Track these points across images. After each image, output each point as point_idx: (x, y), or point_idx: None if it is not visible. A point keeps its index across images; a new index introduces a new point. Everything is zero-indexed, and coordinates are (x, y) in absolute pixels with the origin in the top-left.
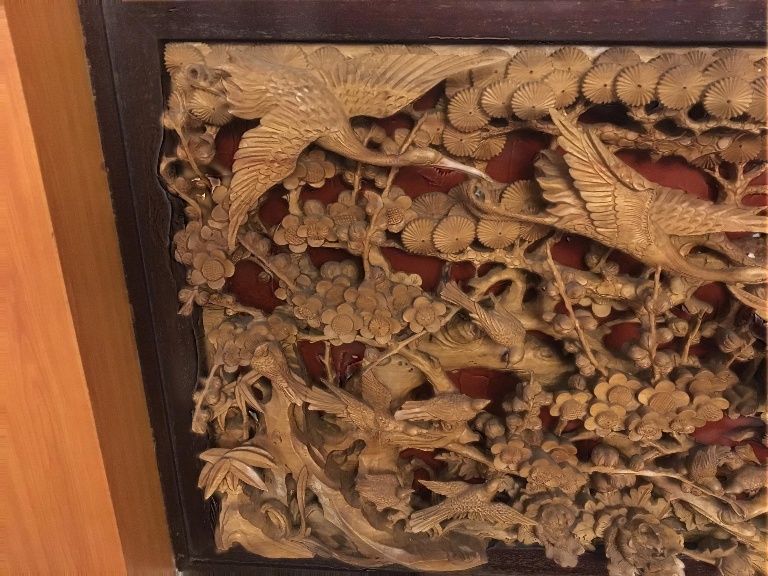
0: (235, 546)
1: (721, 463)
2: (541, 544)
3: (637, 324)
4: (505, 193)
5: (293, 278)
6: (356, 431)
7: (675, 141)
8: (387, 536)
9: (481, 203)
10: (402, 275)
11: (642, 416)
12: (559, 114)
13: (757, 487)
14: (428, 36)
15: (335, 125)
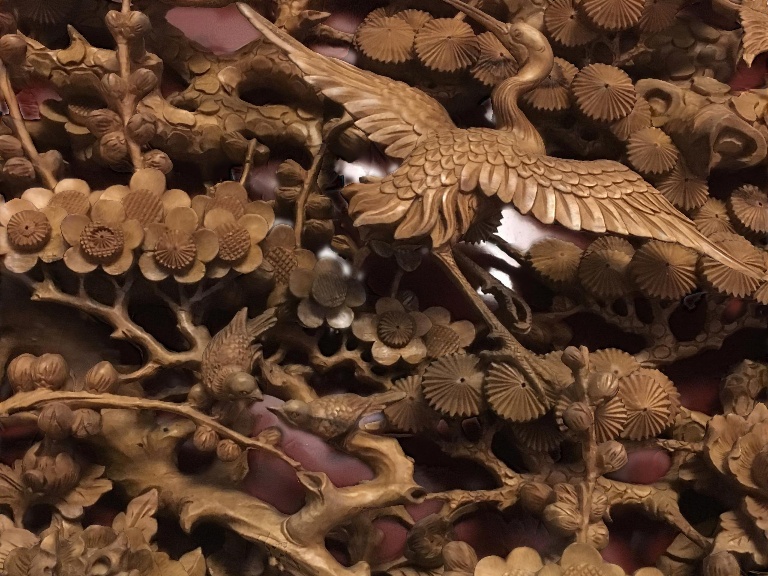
0: None
1: (275, 382)
2: None
3: None
4: None
5: None
6: None
7: None
8: None
9: None
10: None
11: None
12: None
13: (341, 415)
14: None
15: None
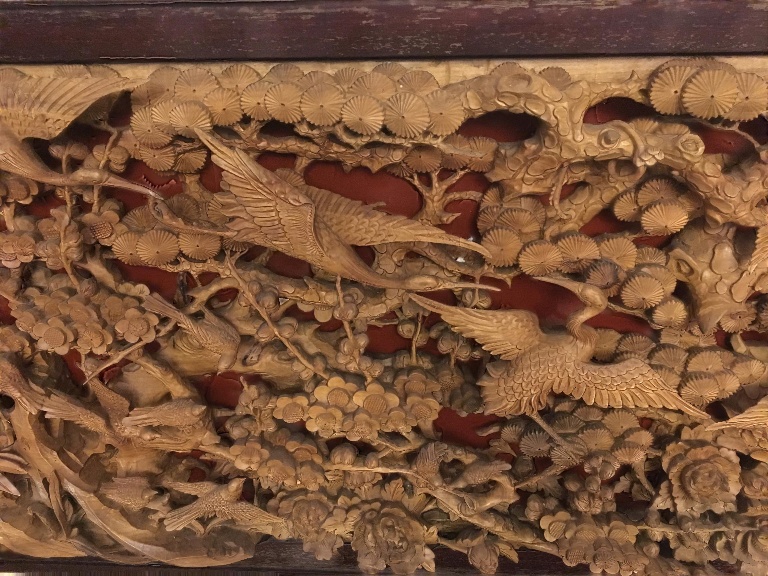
0: (2, 548)
1: (450, 459)
2: (302, 538)
3: (372, 326)
4: (209, 205)
5: (11, 292)
6: (104, 436)
7: (356, 153)
8: (149, 535)
9: (161, 219)
10: (128, 286)
11: (353, 418)
12: (205, 134)
13: (481, 481)
14: (98, 56)
15: (1, 148)
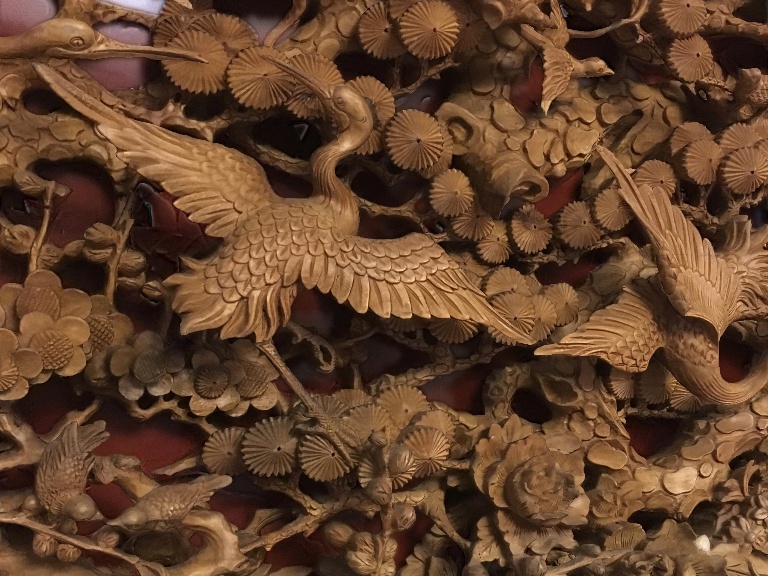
0: None
1: (107, 479)
2: None
3: None
4: None
5: None
6: None
7: None
8: None
9: None
10: None
11: None
12: None
13: (175, 513)
14: None
15: None
